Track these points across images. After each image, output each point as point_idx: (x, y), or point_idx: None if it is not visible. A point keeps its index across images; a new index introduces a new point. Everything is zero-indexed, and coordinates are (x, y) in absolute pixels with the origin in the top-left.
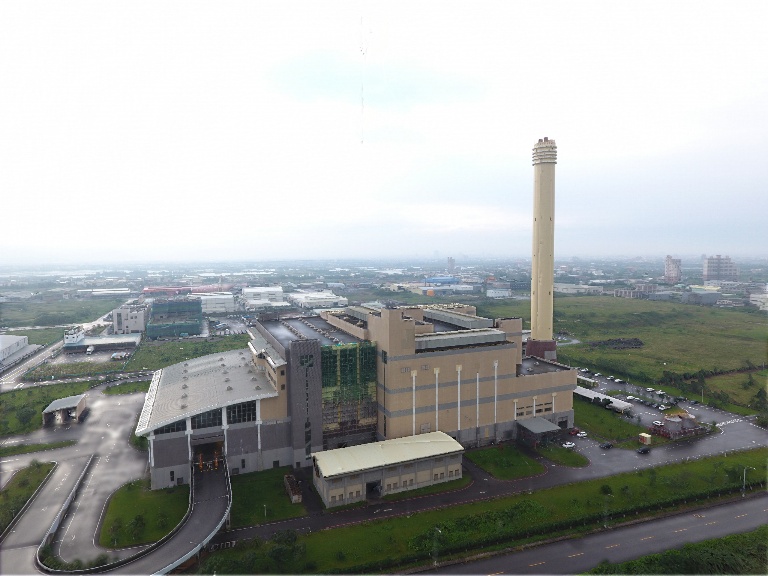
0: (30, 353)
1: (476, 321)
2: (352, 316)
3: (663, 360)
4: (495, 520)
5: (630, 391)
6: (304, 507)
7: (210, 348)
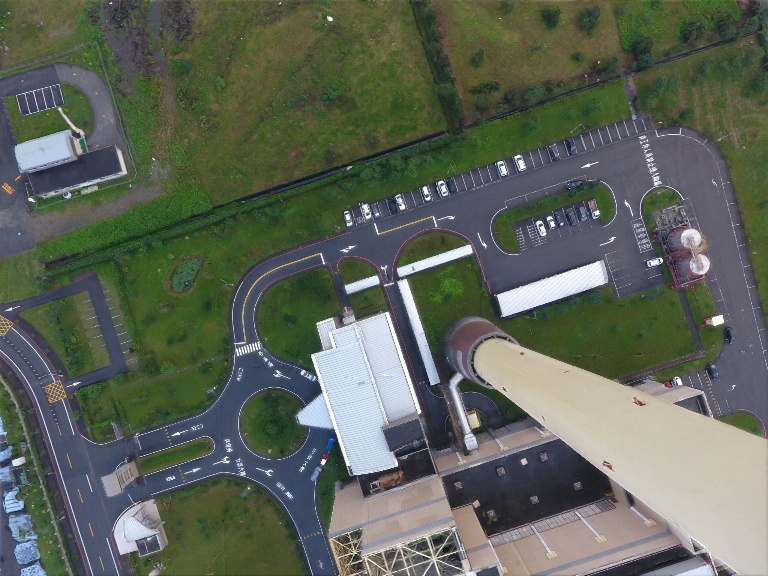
0: None
1: None
2: None
3: (304, 4)
4: None
5: (500, 204)
6: None
7: None
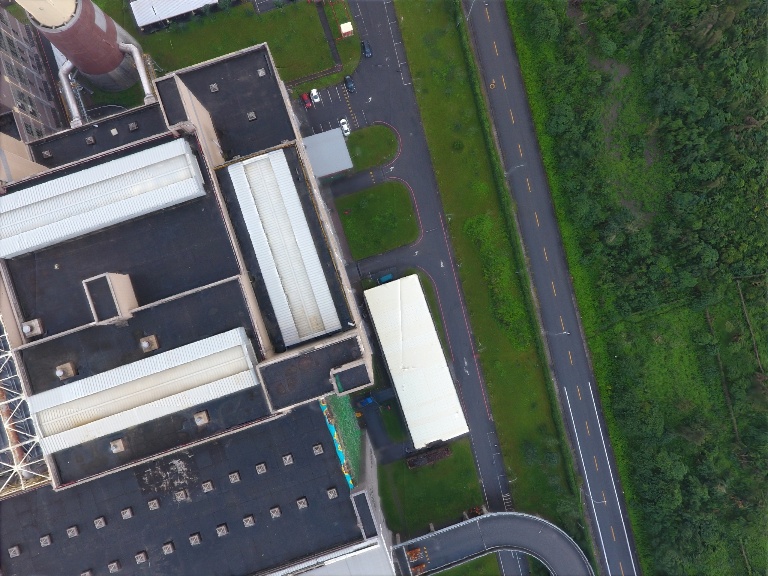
0: None
1: (196, 178)
2: None
3: None
4: (501, 271)
5: None
6: (455, 441)
7: None
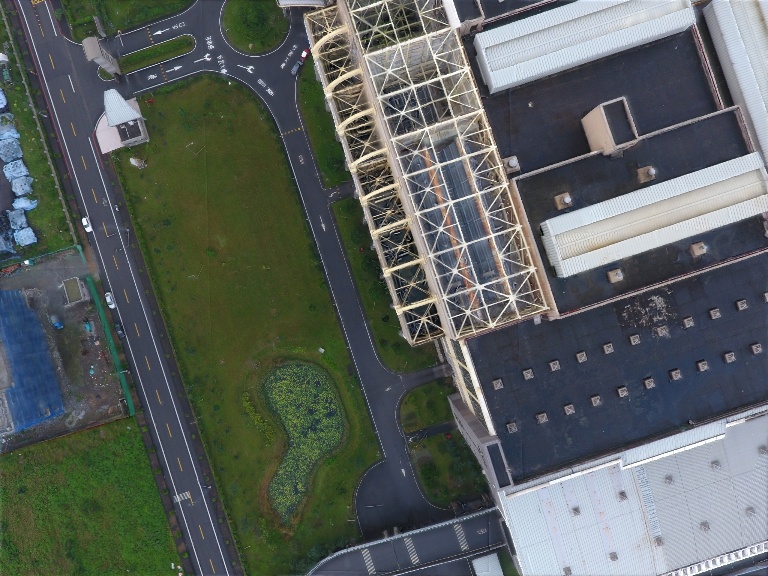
0: None
1: (692, 8)
2: (609, 263)
3: None
4: None
5: None
6: None
7: None
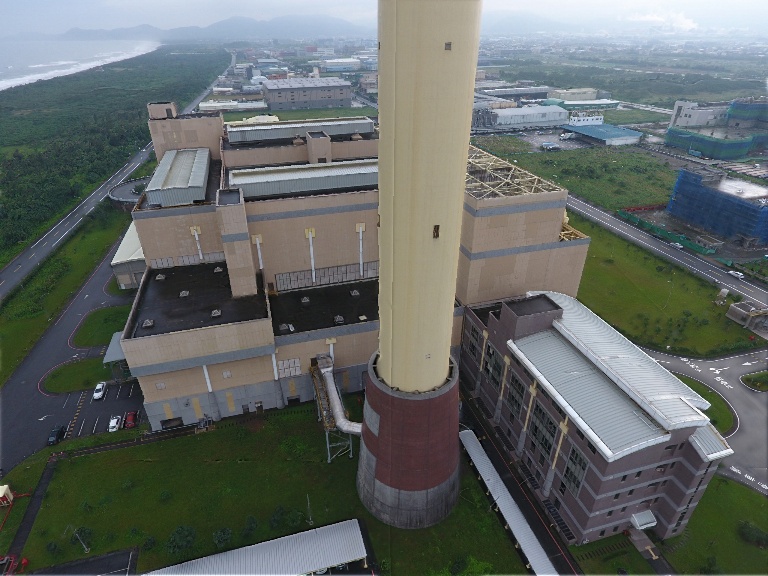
0: (546, 126)
1: None
2: None
3: None
4: None
5: None
6: None
7: (611, 169)
